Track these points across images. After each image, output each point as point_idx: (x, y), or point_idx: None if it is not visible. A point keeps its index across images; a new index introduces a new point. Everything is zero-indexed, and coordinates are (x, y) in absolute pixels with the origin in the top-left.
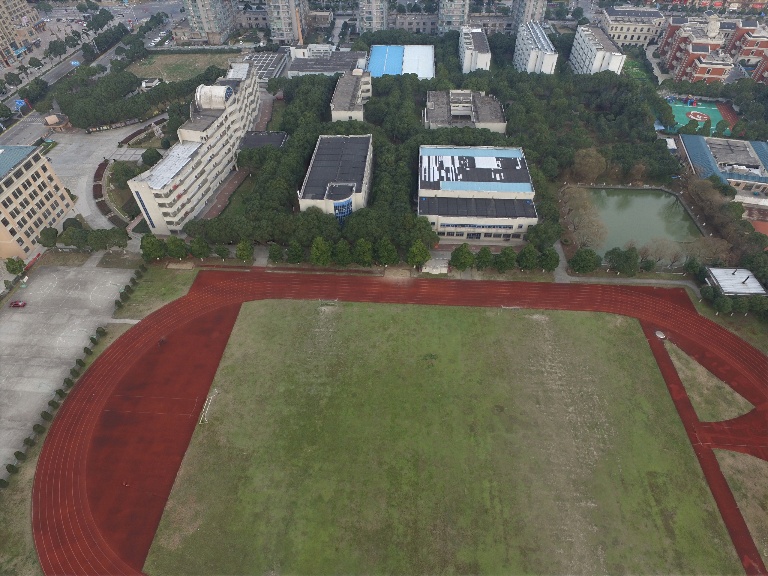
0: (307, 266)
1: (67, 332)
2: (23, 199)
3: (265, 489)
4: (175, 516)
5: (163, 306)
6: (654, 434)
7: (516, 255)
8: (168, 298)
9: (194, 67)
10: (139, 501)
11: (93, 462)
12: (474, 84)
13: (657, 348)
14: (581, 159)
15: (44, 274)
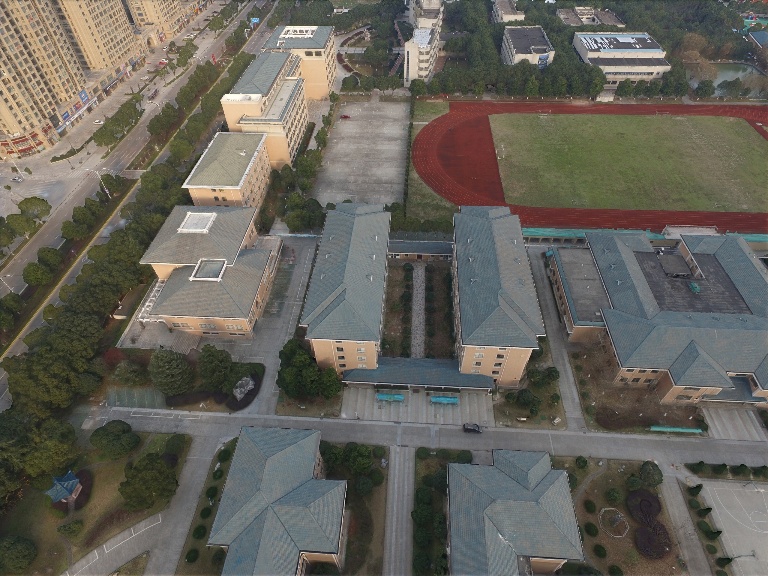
0: (519, 100)
1: (387, 128)
2: (329, 59)
3: (553, 178)
4: (510, 187)
5: (439, 117)
6: (766, 158)
7: (660, 86)
8: (439, 114)
9: (358, 3)
10: (486, 183)
11: (448, 172)
12: (593, 3)
13: (759, 129)
14: (689, 39)
15: (348, 105)
